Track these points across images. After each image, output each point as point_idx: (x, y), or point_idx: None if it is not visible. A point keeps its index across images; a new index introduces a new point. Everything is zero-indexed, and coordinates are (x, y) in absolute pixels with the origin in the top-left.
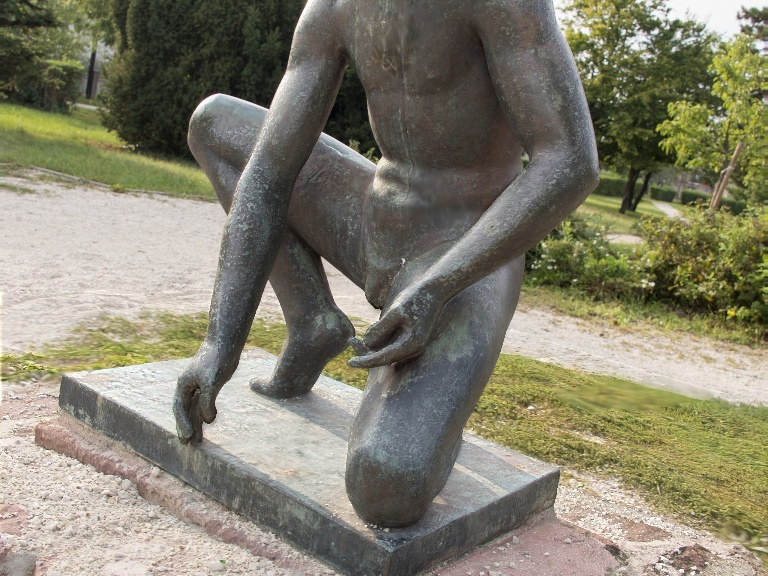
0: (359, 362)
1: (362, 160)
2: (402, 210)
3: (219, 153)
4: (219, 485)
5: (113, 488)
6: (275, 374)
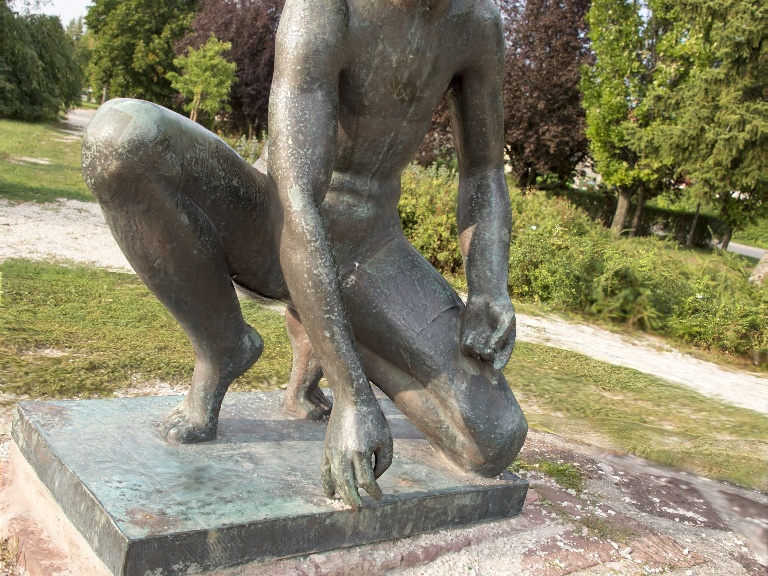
0: None
1: None
2: (367, 220)
3: (179, 184)
4: (390, 525)
5: None
6: (210, 415)
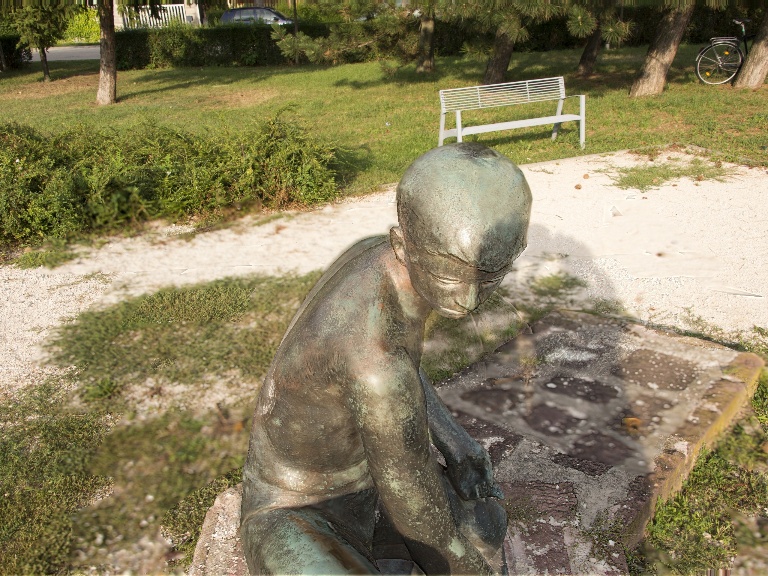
0: None
1: (306, 516)
2: None
3: None
4: None
5: None
6: None
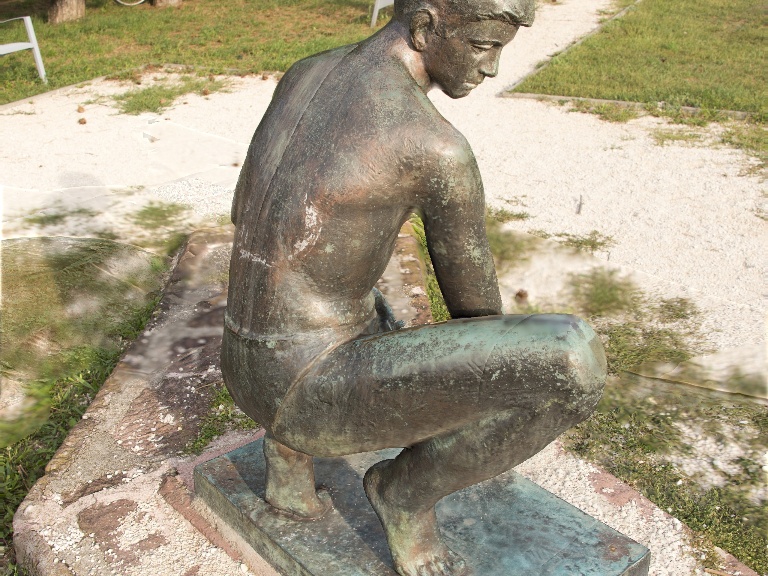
0: None
1: (380, 334)
2: None
3: None
4: None
5: None
6: None
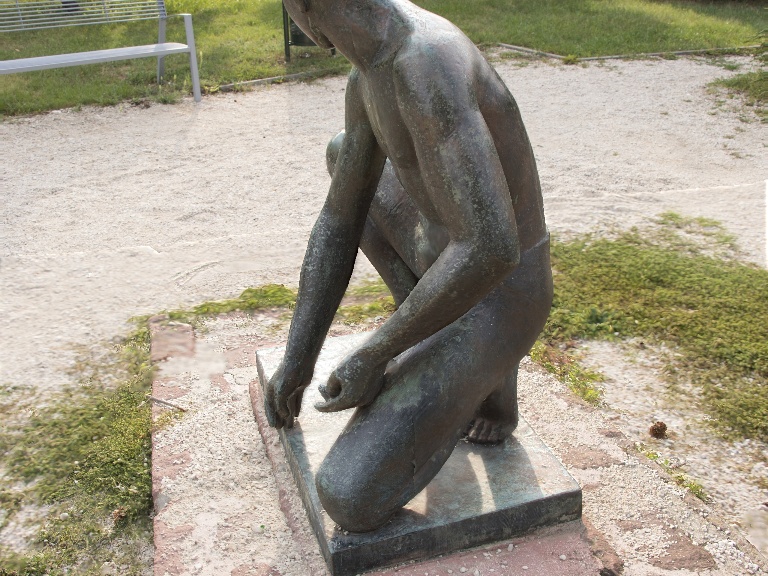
0: (317, 407)
1: None
2: (421, 256)
3: None
4: None
5: (250, 449)
6: None
